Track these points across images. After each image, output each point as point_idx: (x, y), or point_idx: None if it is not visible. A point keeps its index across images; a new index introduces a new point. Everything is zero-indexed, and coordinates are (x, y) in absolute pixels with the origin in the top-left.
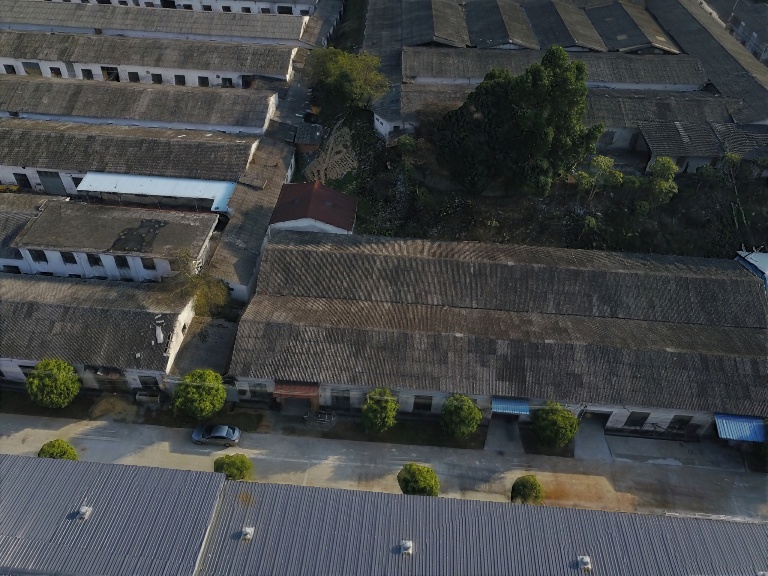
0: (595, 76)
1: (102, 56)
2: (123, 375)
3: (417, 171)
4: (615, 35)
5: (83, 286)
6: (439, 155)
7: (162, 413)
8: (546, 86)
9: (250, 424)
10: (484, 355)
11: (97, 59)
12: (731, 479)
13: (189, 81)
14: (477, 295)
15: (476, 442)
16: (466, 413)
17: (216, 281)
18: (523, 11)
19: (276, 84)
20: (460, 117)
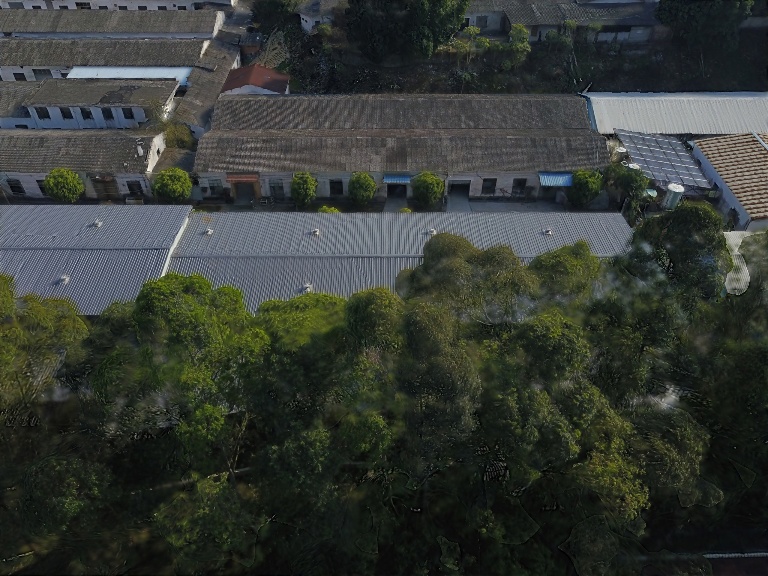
0: None
1: None
2: (115, 181)
3: (334, 52)
4: None
5: (79, 131)
6: (348, 33)
7: None
8: None
9: (212, 211)
10: (377, 148)
11: None
12: None
13: None
14: (376, 121)
15: (376, 211)
16: (363, 180)
17: (181, 124)
18: None
19: (223, 8)
20: None
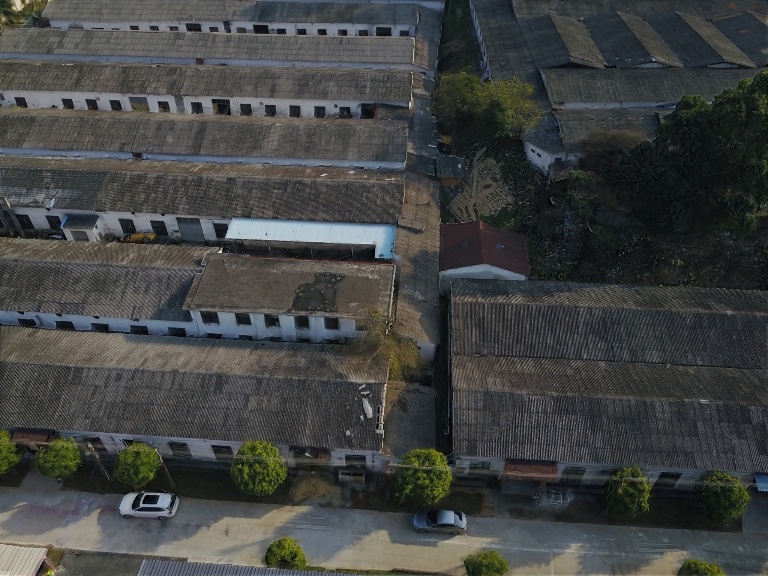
0: None
1: (213, 88)
2: None
3: None
4: (759, 49)
5: (264, 351)
6: (622, 191)
7: (370, 495)
8: (762, 116)
9: (471, 506)
10: (738, 425)
11: (208, 92)
12: None
13: (304, 111)
14: (699, 350)
15: (731, 523)
16: (737, 496)
17: (406, 341)
18: (648, 25)
19: (399, 112)
20: (655, 151)
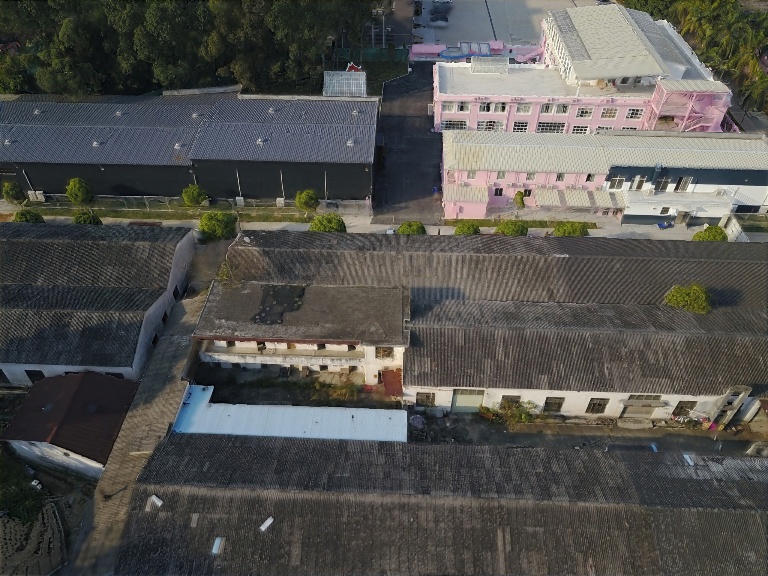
0: None
1: None
2: None
3: None
4: None
5: (332, 283)
6: None
7: None
8: None
9: None
10: None
11: None
12: None
13: None
14: None
15: None
16: None
17: None
18: None
19: None
20: None
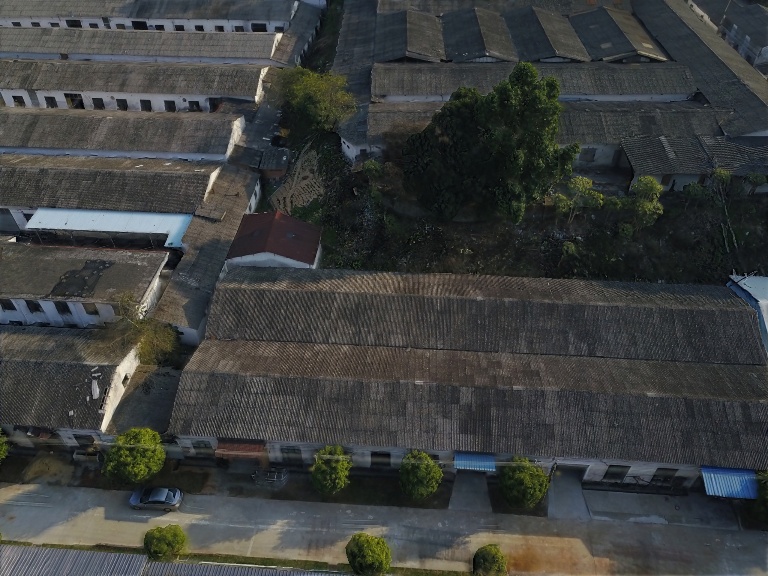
0: (576, 88)
1: (65, 83)
2: (57, 434)
3: (384, 197)
4: (599, 43)
5: (21, 335)
6: (405, 181)
7: (101, 474)
8: (513, 106)
9: (194, 484)
10: (446, 405)
11: (60, 86)
12: (723, 539)
13: (155, 106)
14: (443, 334)
15: (440, 500)
16: (424, 473)
17: (163, 325)
18: (503, 21)
19: (244, 106)
20: (424, 141)
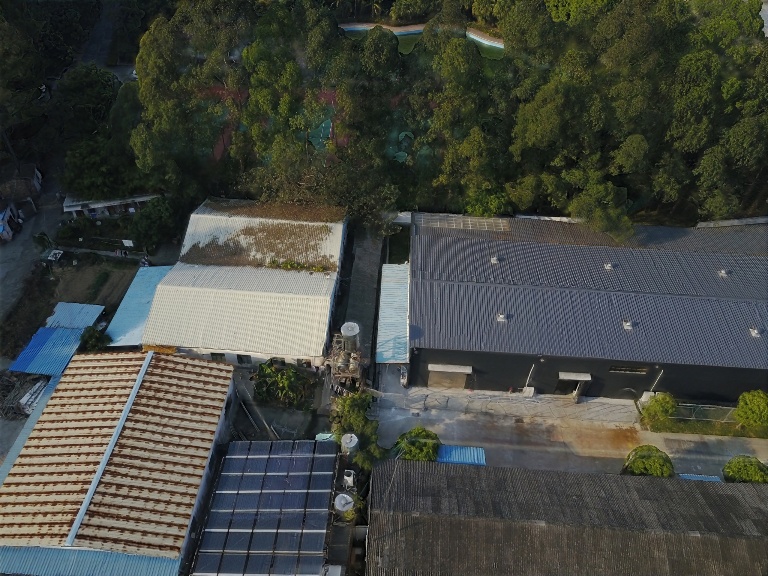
0: None
1: None
2: None
3: None
4: None
5: None
6: None
7: None
8: None
9: None
10: (765, 519)
11: None
12: None
13: None
14: None
15: None
16: None
17: None
18: None
19: None
20: None
